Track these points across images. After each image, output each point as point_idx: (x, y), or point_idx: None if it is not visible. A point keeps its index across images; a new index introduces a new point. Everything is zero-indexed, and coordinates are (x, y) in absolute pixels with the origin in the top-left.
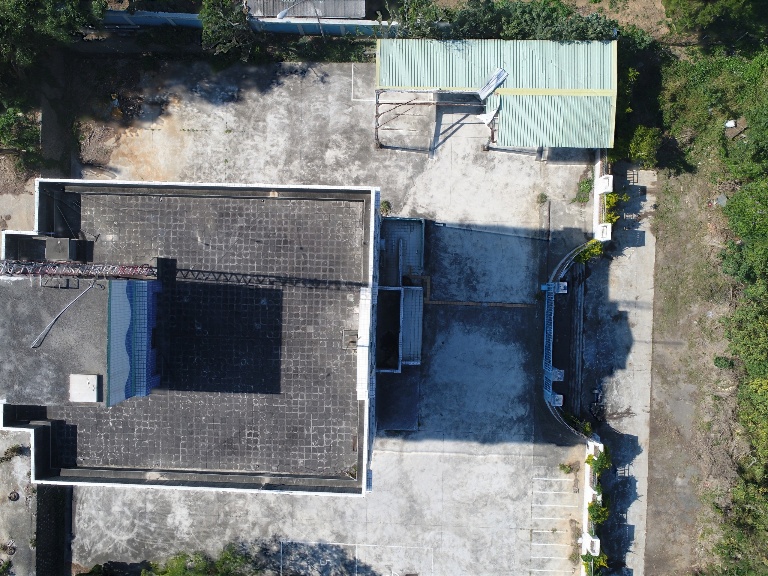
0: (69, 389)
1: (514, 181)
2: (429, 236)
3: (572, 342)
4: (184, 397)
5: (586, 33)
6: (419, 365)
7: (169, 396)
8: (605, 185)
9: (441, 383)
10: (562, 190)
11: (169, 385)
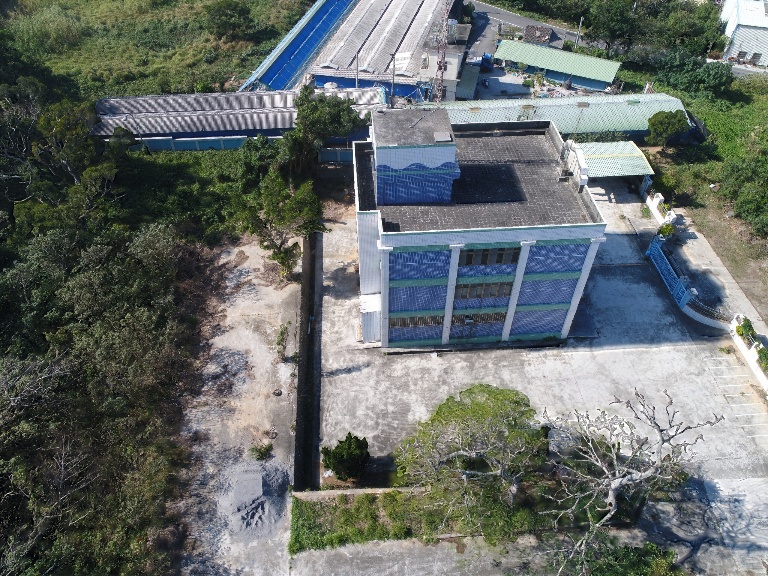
0: (433, 139)
1: None
2: None
3: None
4: (467, 206)
5: (614, 139)
6: (582, 299)
7: (457, 207)
8: None
9: (603, 308)
10: (632, 213)
11: (456, 202)
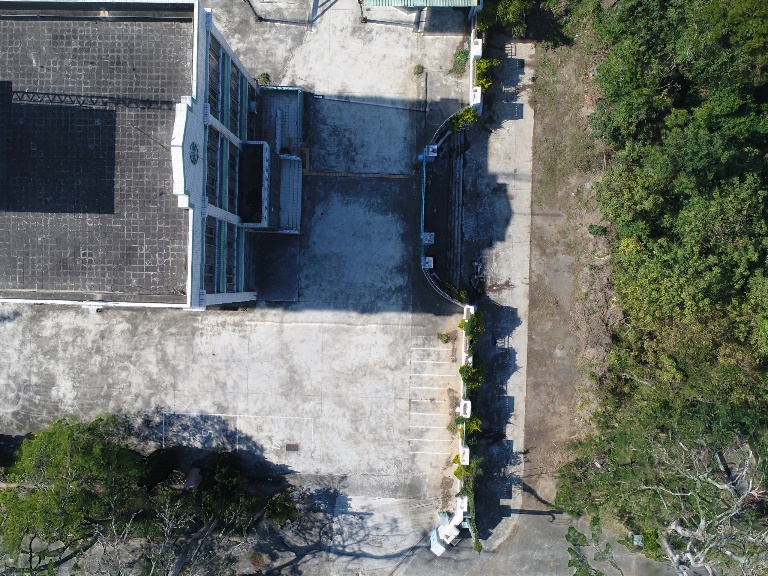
0: None
1: (391, 53)
2: (308, 108)
3: (450, 213)
4: (20, 218)
5: None
6: (299, 236)
7: (5, 217)
8: (476, 51)
9: (320, 254)
10: (439, 61)
11: (5, 206)
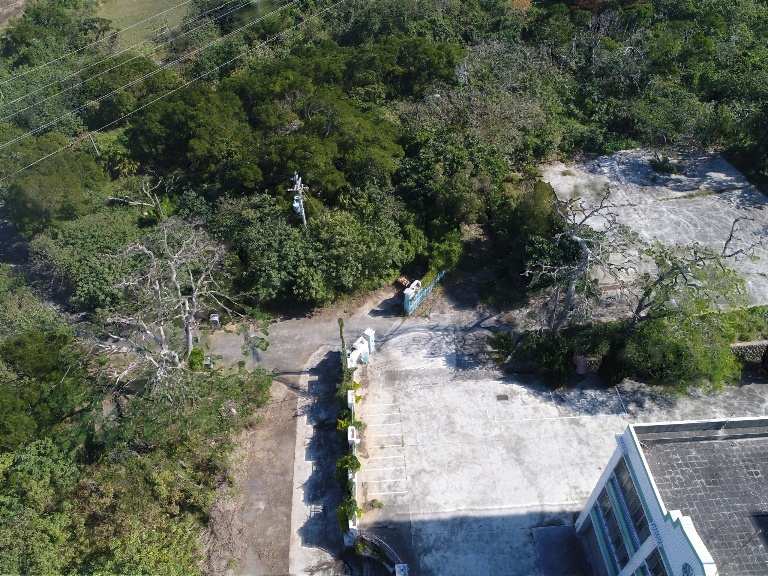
0: None
1: None
2: None
3: None
4: None
5: None
6: None
7: None
8: None
9: None
10: None
11: None
